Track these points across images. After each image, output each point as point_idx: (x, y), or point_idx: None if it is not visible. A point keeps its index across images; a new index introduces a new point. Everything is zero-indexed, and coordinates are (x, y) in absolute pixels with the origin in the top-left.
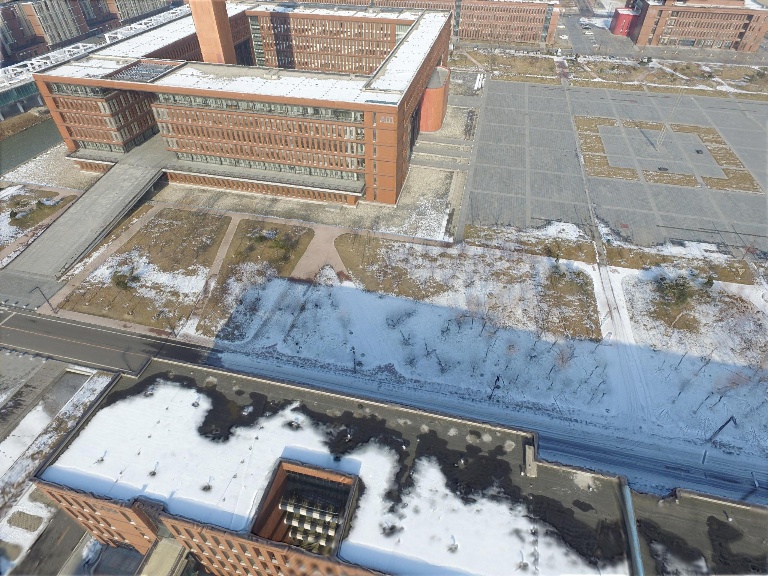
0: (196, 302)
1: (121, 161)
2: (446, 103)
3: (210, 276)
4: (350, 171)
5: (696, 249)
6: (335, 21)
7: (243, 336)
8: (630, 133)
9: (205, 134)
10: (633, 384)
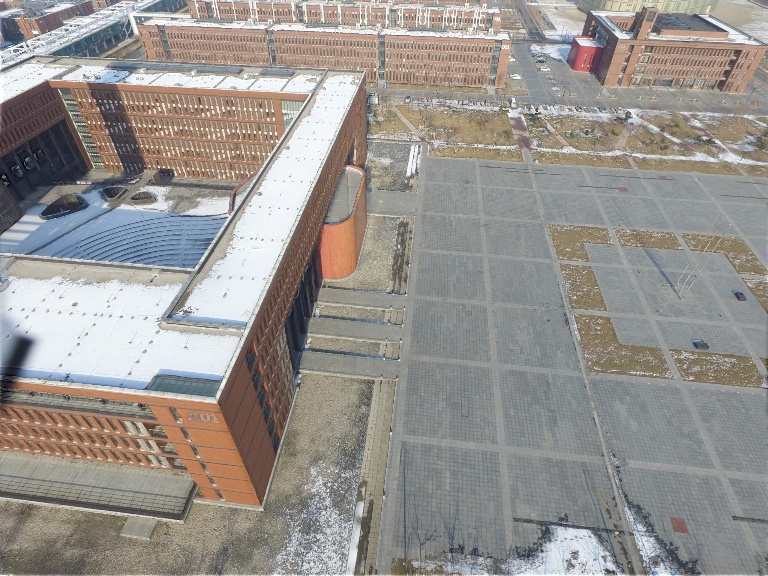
0: None
1: None
2: (363, 221)
3: None
4: (160, 468)
5: None
6: (189, 95)
7: None
8: (633, 259)
9: None
10: None
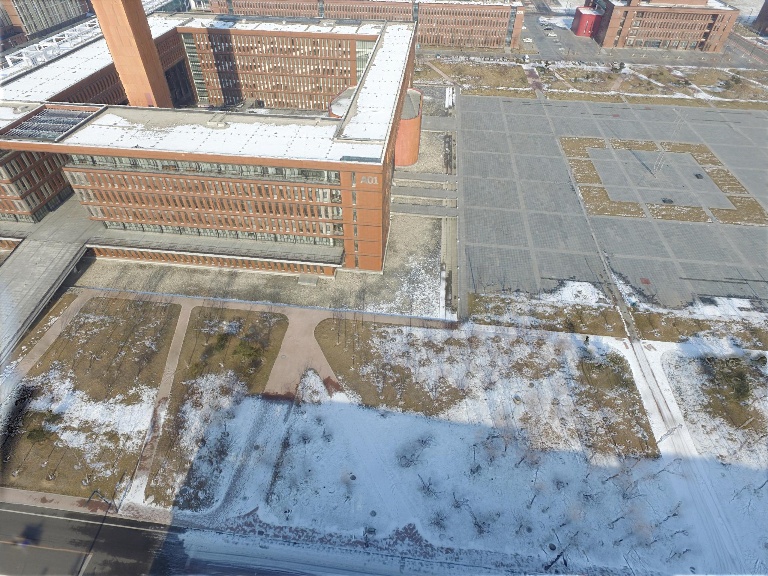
0: (142, 447)
1: (30, 235)
2: (420, 130)
3: (159, 402)
4: (325, 237)
5: (730, 307)
6: (285, 38)
7: (210, 500)
8: (622, 156)
9: (138, 200)
10: (712, 522)
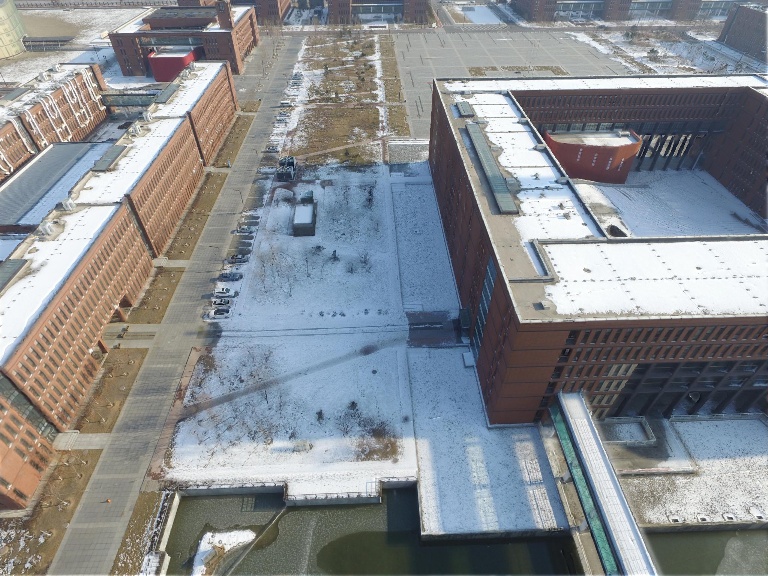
0: None
1: None
2: None
3: None
4: None
5: None
6: None
7: None
8: None
9: None
10: None
